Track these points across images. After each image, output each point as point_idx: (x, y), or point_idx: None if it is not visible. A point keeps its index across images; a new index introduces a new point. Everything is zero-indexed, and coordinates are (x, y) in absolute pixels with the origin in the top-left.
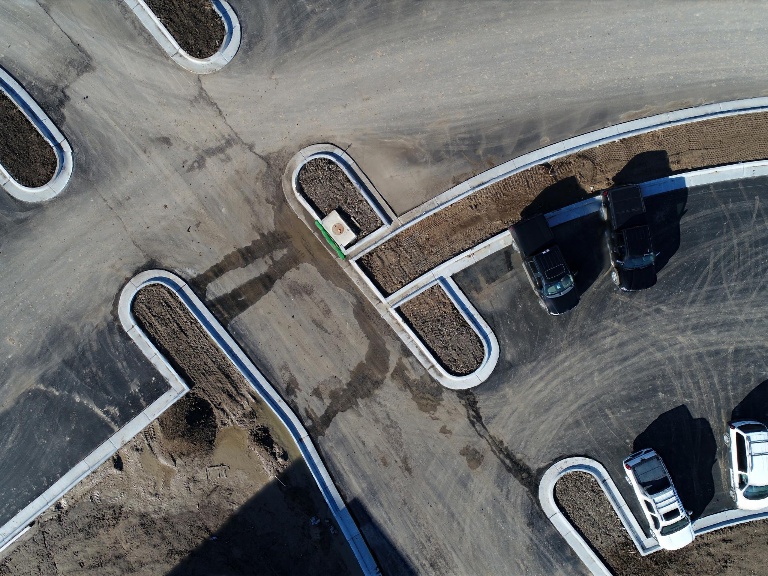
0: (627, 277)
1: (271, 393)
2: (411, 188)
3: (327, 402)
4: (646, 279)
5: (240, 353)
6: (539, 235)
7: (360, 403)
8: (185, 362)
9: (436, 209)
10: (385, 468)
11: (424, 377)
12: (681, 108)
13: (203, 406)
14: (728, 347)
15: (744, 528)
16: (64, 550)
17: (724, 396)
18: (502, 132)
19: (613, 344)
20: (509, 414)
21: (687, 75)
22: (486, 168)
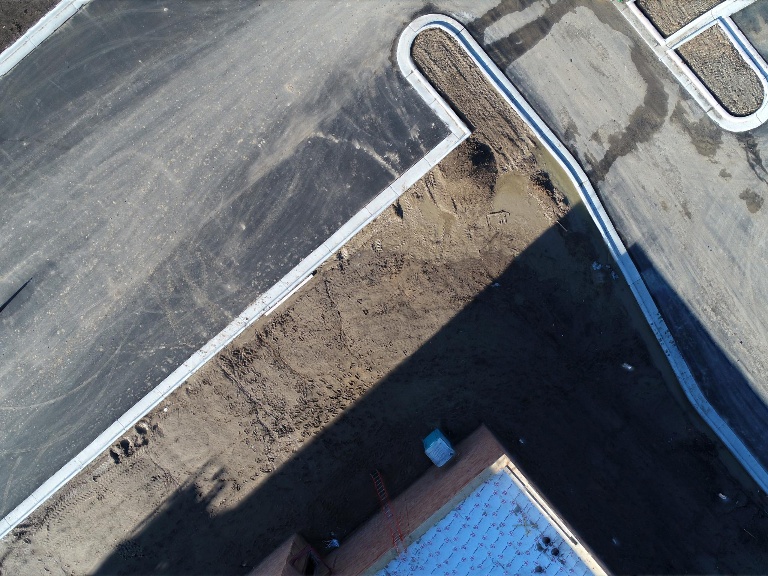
0: None
1: (551, 137)
2: None
3: (606, 146)
4: None
5: (519, 97)
6: None
7: (639, 147)
8: (465, 107)
9: None
10: (665, 212)
11: (703, 120)
12: None
13: (484, 150)
14: None
15: None
16: (347, 298)
17: None
18: None
19: None
20: None
21: None
22: None
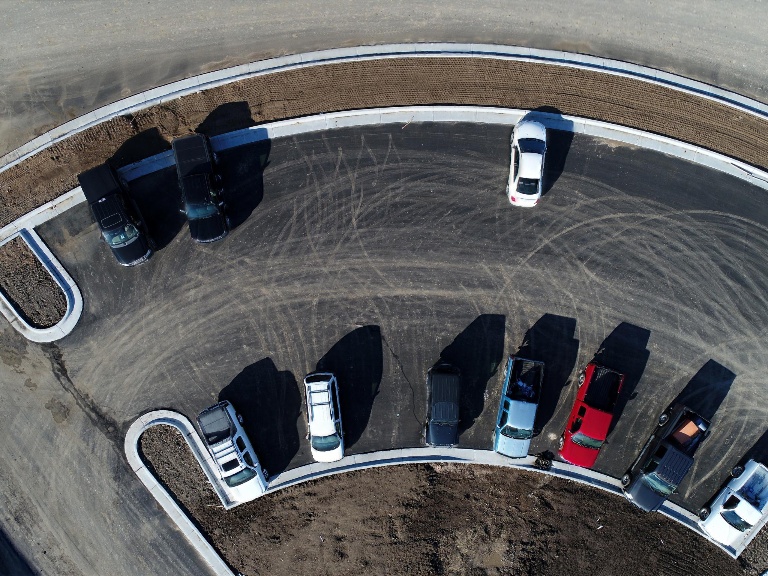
0: (192, 227)
1: None
2: None
3: None
4: (211, 229)
5: None
6: (101, 184)
7: None
8: None
9: (16, 161)
10: None
11: (8, 330)
12: (262, 59)
13: None
14: (312, 299)
15: (328, 481)
16: None
17: (308, 348)
18: (82, 83)
19: (197, 296)
20: (94, 367)
21: (267, 26)
22: (67, 119)
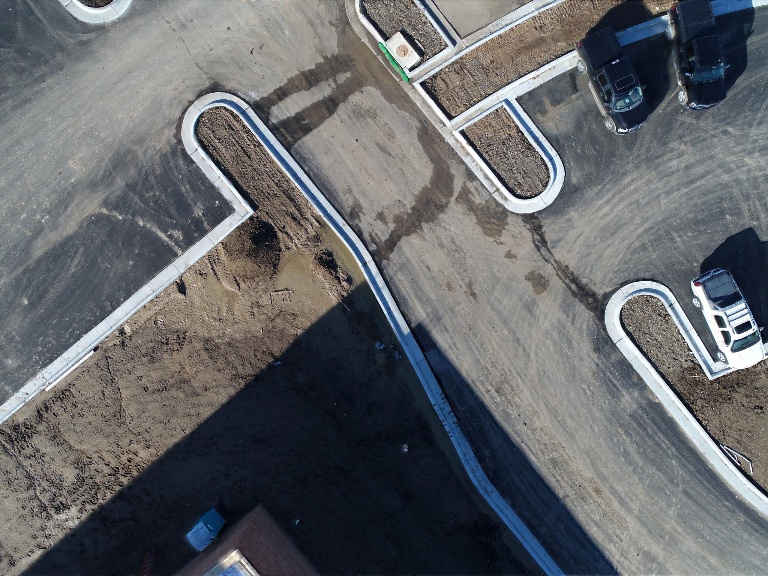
0: (696, 91)
1: (335, 217)
2: (475, 10)
3: (391, 226)
4: (715, 93)
5: (304, 176)
6: (608, 48)
7: (424, 227)
8: (249, 185)
9: (501, 30)
10: (450, 293)
11: (489, 201)
12: None
13: (267, 229)
14: None
15: None
16: (128, 374)
17: None
18: None
19: (679, 166)
20: (575, 238)
21: None
22: None
